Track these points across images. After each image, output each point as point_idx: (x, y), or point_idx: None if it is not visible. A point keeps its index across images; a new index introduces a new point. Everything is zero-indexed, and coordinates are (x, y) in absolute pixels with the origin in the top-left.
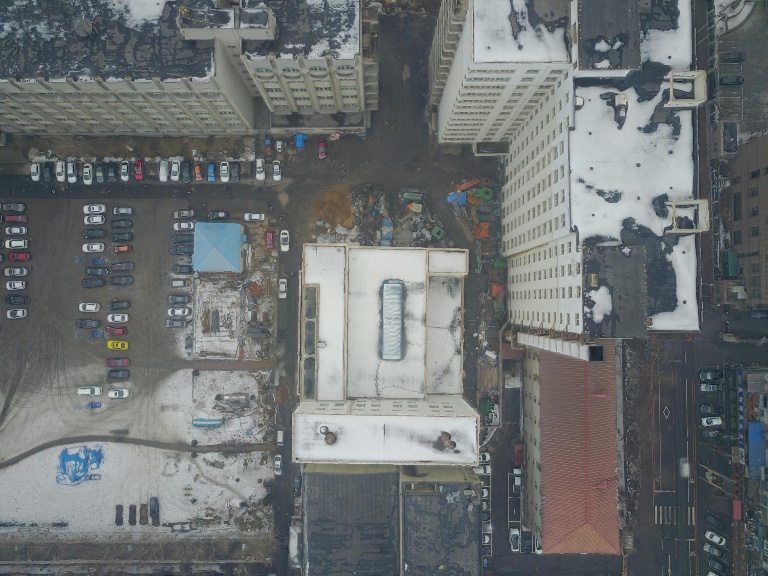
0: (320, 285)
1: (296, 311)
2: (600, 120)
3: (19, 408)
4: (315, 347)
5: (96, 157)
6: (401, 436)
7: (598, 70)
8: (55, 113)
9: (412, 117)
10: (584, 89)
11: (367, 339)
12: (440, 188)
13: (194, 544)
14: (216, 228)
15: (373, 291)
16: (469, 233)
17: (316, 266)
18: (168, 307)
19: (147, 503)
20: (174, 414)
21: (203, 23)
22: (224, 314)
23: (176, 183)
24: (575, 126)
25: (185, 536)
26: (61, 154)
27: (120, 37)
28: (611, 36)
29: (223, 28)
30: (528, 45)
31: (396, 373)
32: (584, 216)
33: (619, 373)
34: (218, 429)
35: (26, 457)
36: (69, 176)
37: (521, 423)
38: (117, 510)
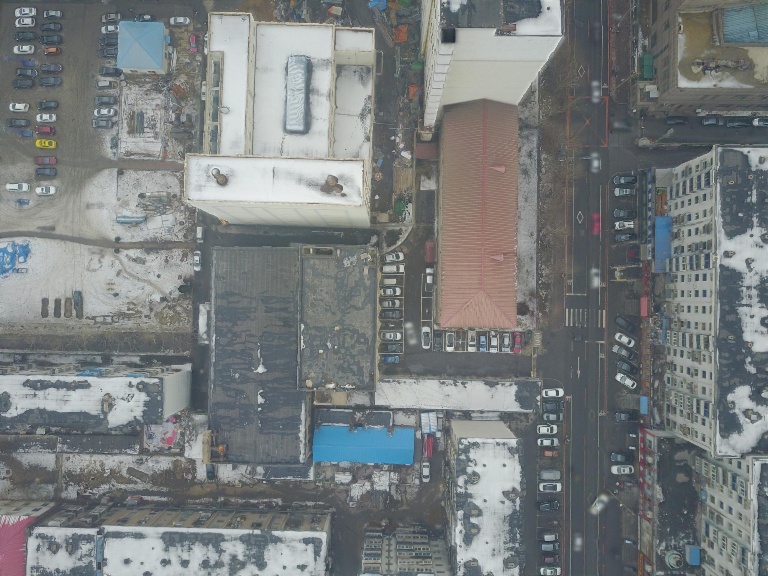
0: (225, 53)
1: None
2: None
3: None
4: (218, 112)
5: None
6: (290, 179)
7: None
8: None
9: None
10: None
11: (273, 113)
12: None
13: (116, 337)
14: (139, 25)
15: (280, 67)
16: (389, 38)
17: (221, 34)
18: (95, 108)
19: (72, 297)
20: (99, 212)
21: None
22: (148, 115)
23: None
24: None
25: (107, 328)
26: None
27: None
28: None
29: None
30: None
31: (300, 146)
32: None
33: None
34: (140, 225)
35: None
36: None
37: (435, 225)
38: (43, 303)
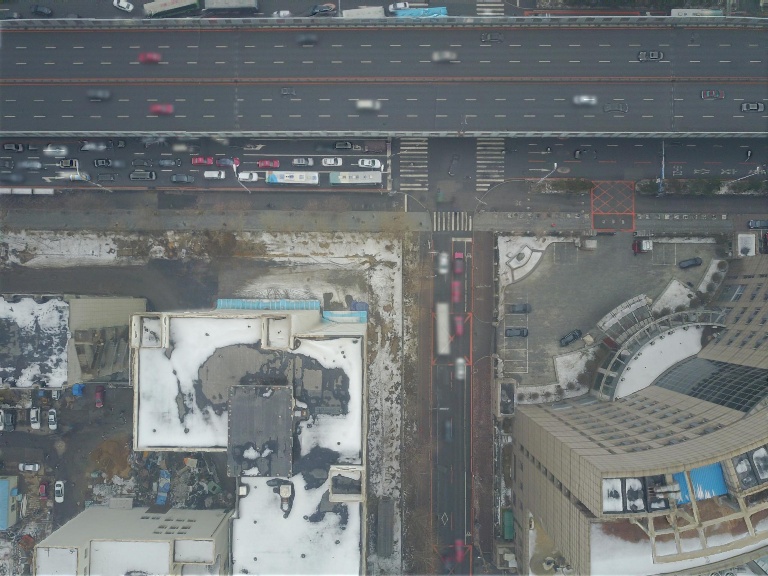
0: None
1: None
2: (266, 508)
3: None
4: None
5: None
6: None
7: None
8: None
9: None
10: None
11: None
12: None
13: None
14: None
15: None
16: None
17: (48, 568)
18: None
19: None
20: None
21: None
22: None
23: None
24: (239, 515)
25: None
26: None
27: None
28: (260, 443)
29: None
30: (194, 428)
31: None
32: None
33: None
34: None
35: None
36: None
37: None
38: None
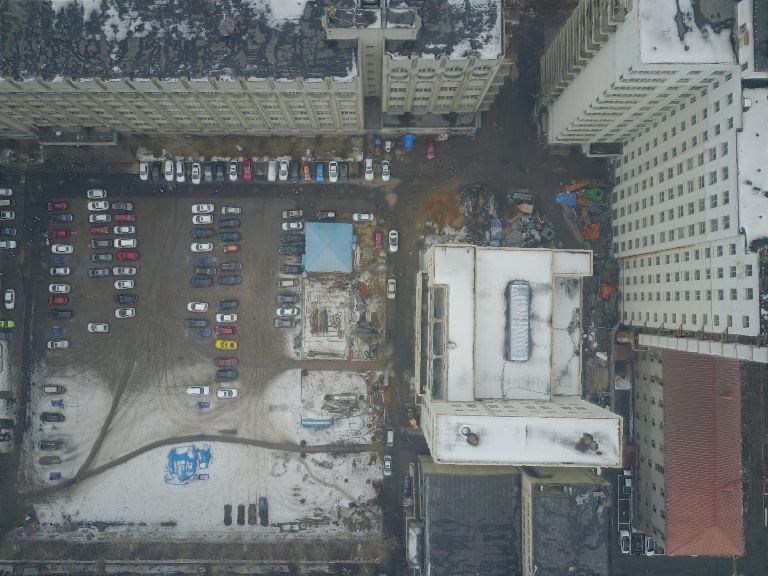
0: (450, 286)
1: (405, 311)
2: (767, 122)
3: (127, 407)
4: (445, 348)
5: (204, 156)
6: (543, 437)
7: None
8: (176, 112)
9: (520, 117)
10: (751, 90)
11: (492, 340)
12: (549, 189)
13: (302, 544)
14: (328, 228)
15: (498, 292)
16: (578, 234)
17: (445, 267)
18: (276, 307)
19: (256, 503)
20: (282, 414)
21: (350, 23)
22: (333, 314)
23: (284, 183)
24: (742, 127)
25: (294, 536)
26: None
27: (261, 36)
28: None
29: (370, 28)
30: (694, 46)
31: (521, 374)
32: (752, 218)
33: None
34: (327, 429)
35: (134, 456)
36: (178, 175)
37: (631, 425)
38: (225, 510)
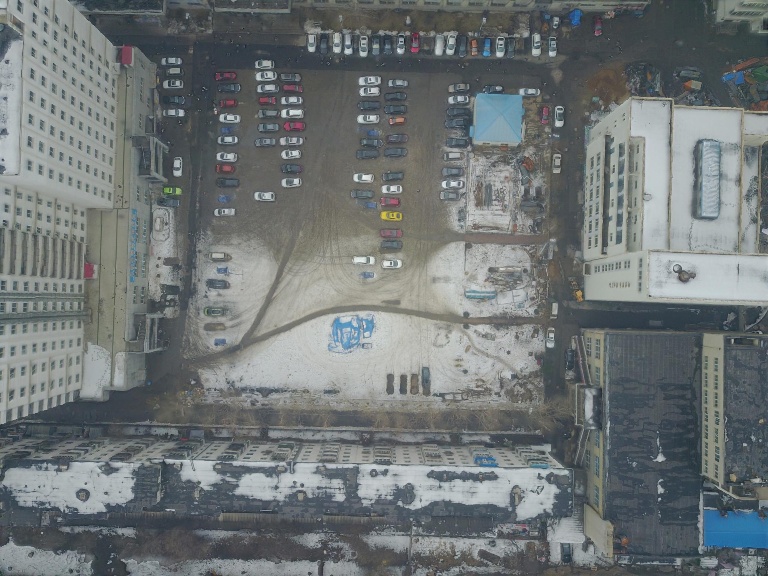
0: (645, 138)
1: (569, 187)
2: None
3: (292, 276)
4: (641, 199)
5: (371, 30)
6: (755, 276)
7: None
8: None
9: None
10: None
11: (681, 198)
12: (715, 68)
13: (464, 415)
14: (500, 98)
15: (687, 150)
16: None
17: (641, 120)
18: (441, 180)
19: (418, 373)
20: (446, 286)
21: None
22: (497, 188)
23: (450, 57)
24: None
25: (456, 406)
26: (337, 26)
27: None
28: None
29: None
30: None
31: (709, 232)
32: None
33: None
34: (492, 301)
35: (298, 324)
36: (346, 47)
37: None
38: (388, 379)
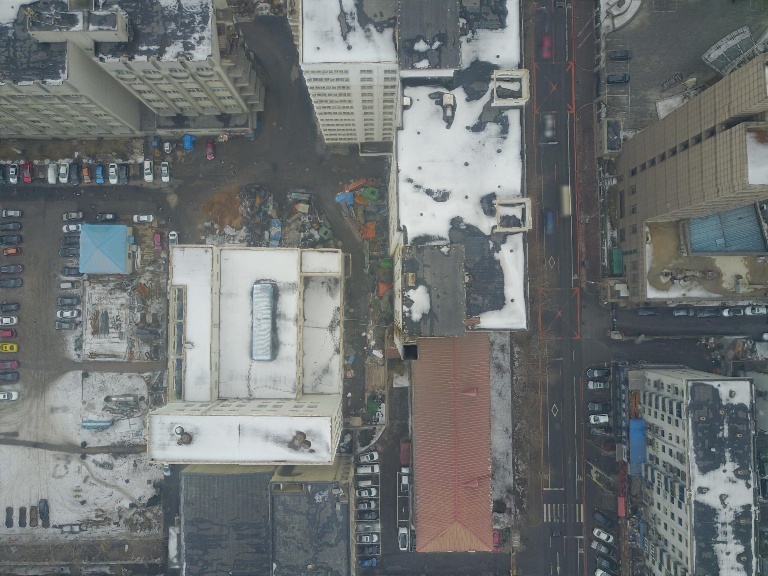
0: (187, 286)
1: None
2: (429, 120)
3: None
4: (182, 348)
5: None
6: (256, 436)
7: (418, 70)
8: None
9: (301, 118)
10: (413, 89)
11: (239, 340)
12: (328, 188)
13: (84, 545)
14: (101, 230)
15: (245, 292)
16: (357, 233)
17: (184, 267)
18: (58, 309)
19: (37, 505)
20: (64, 416)
21: (52, 26)
22: (113, 316)
23: (65, 185)
24: (403, 126)
25: (75, 537)
26: None
27: None
28: (430, 36)
29: (72, 31)
30: (357, 45)
31: (268, 373)
32: (413, 215)
33: (507, 371)
34: (107, 430)
35: None
36: None
37: (409, 422)
38: (7, 512)
